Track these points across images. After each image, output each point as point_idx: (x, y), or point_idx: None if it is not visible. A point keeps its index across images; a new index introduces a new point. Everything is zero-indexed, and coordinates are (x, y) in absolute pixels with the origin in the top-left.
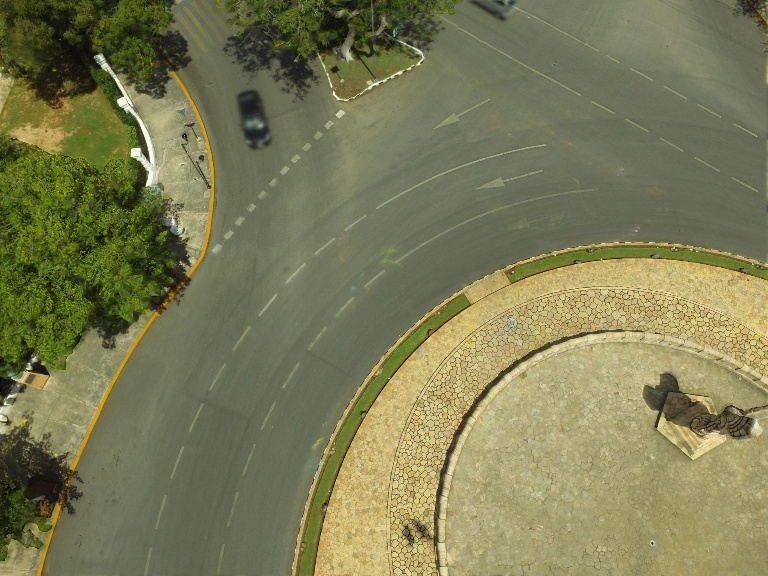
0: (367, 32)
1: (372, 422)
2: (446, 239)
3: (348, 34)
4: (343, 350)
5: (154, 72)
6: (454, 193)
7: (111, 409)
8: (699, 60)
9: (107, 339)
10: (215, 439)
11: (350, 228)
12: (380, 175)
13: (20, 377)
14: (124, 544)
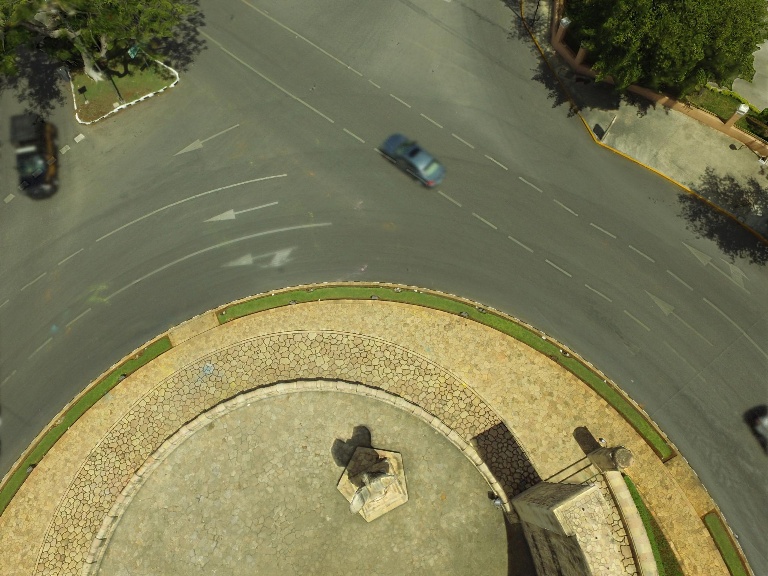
0: (97, 53)
1: (38, 477)
2: (162, 275)
3: (81, 54)
4: (28, 396)
5: None
6: (181, 225)
7: None
8: (463, 86)
9: None
10: None
11: (64, 262)
12: (107, 205)
13: None
14: None
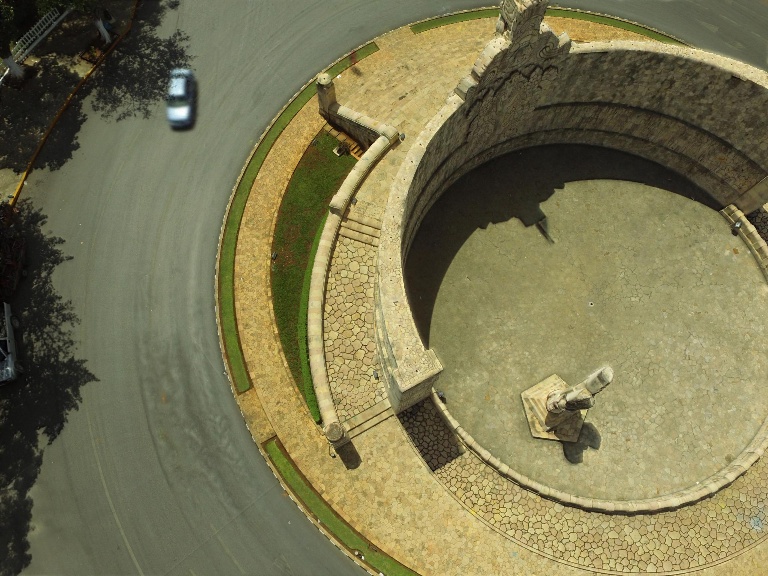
0: None
1: None
2: None
3: None
4: None
5: None
6: None
7: None
8: None
9: None
10: None
11: None
12: None
13: None
14: None
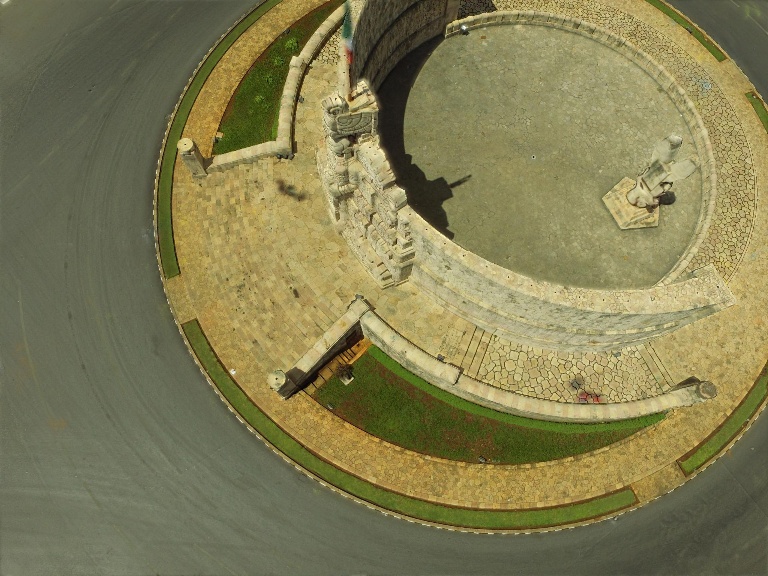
0: None
1: None
2: None
3: None
4: None
5: None
6: None
7: None
8: None
9: None
10: None
11: None
12: None
13: None
14: None
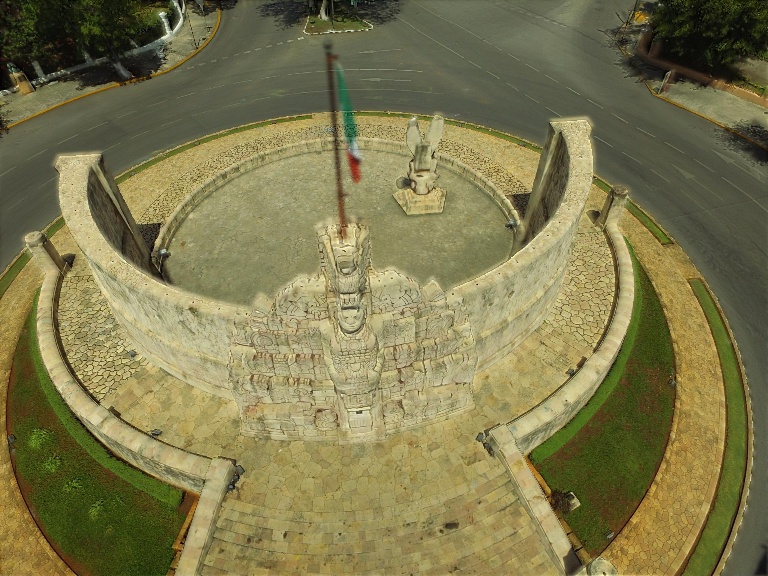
0: None
1: (200, 148)
2: (321, 93)
3: None
4: (213, 120)
5: (209, 8)
6: (344, 78)
7: (54, 112)
8: (560, 59)
9: (81, 86)
10: (100, 136)
11: (265, 78)
12: (303, 63)
13: (17, 72)
14: (3, 161)
